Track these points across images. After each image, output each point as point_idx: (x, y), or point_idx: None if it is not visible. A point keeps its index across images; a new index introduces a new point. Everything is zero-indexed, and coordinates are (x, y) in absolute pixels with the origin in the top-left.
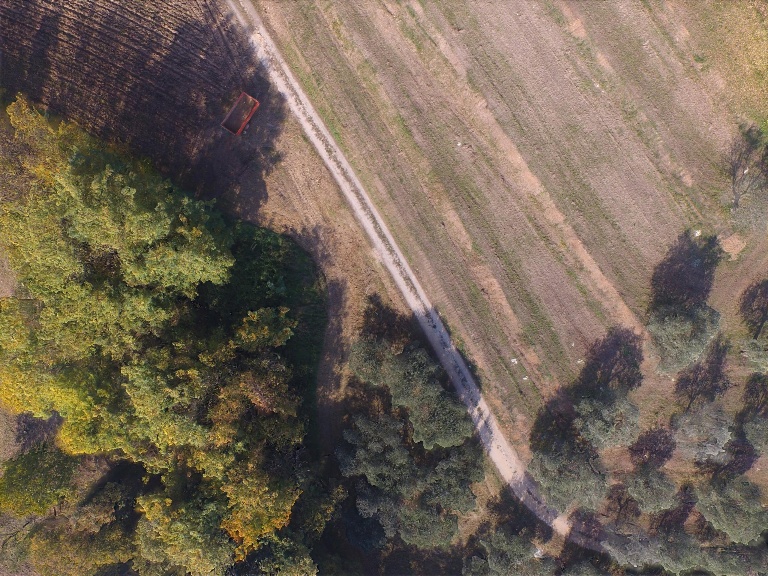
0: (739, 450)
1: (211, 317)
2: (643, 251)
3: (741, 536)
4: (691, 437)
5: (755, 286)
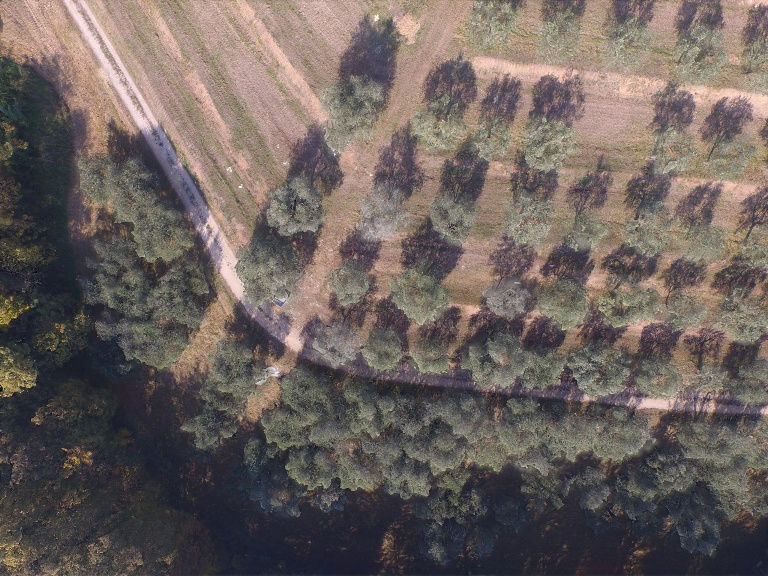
0: (442, 247)
1: None
2: (329, 41)
3: (419, 315)
4: (393, 234)
5: (436, 71)
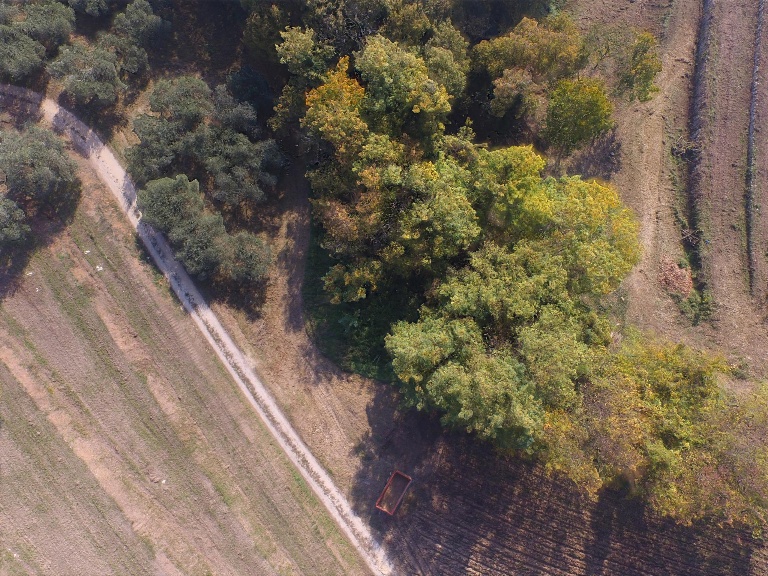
0: None
1: (417, 286)
2: None
3: None
4: None
5: None
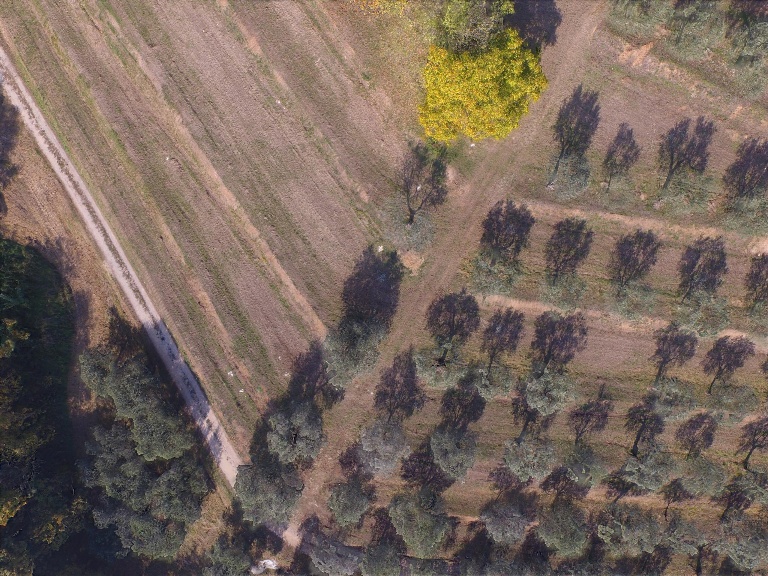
0: None
1: None
2: (332, 266)
3: (418, 550)
4: None
5: (439, 301)
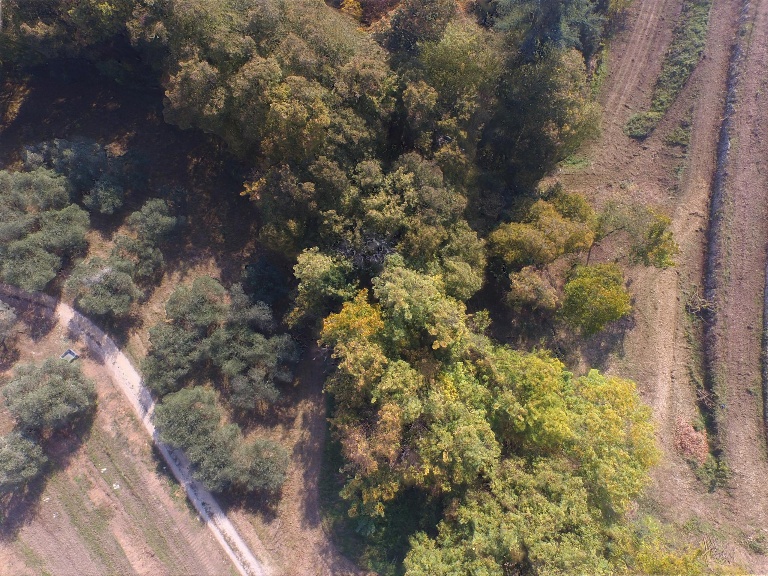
0: None
1: None
2: None
3: None
4: None
5: None
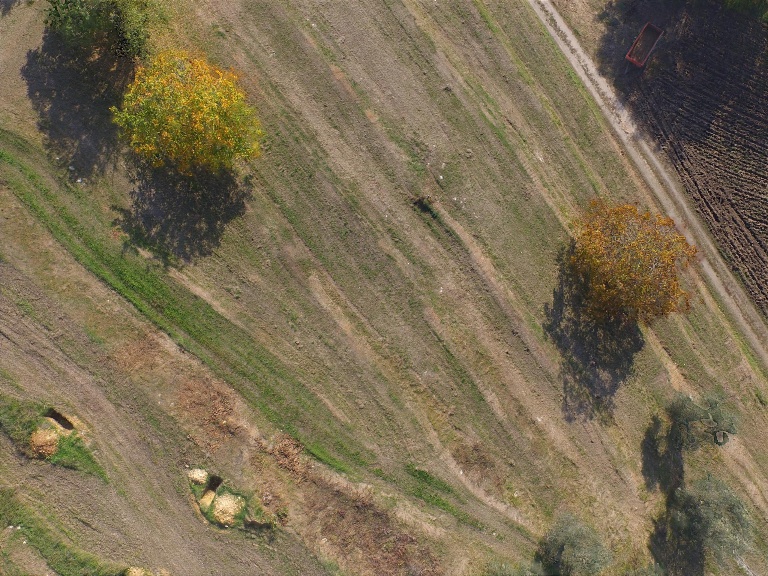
0: None
1: None
2: None
3: None
4: None
5: None
